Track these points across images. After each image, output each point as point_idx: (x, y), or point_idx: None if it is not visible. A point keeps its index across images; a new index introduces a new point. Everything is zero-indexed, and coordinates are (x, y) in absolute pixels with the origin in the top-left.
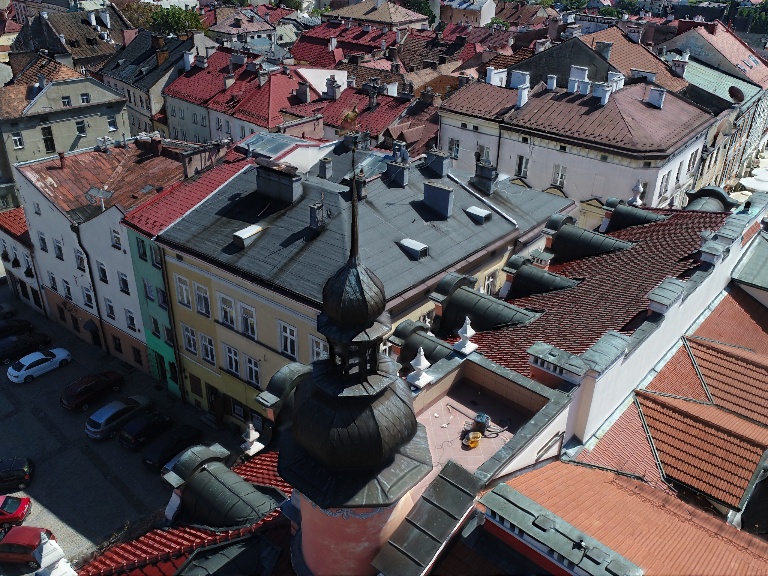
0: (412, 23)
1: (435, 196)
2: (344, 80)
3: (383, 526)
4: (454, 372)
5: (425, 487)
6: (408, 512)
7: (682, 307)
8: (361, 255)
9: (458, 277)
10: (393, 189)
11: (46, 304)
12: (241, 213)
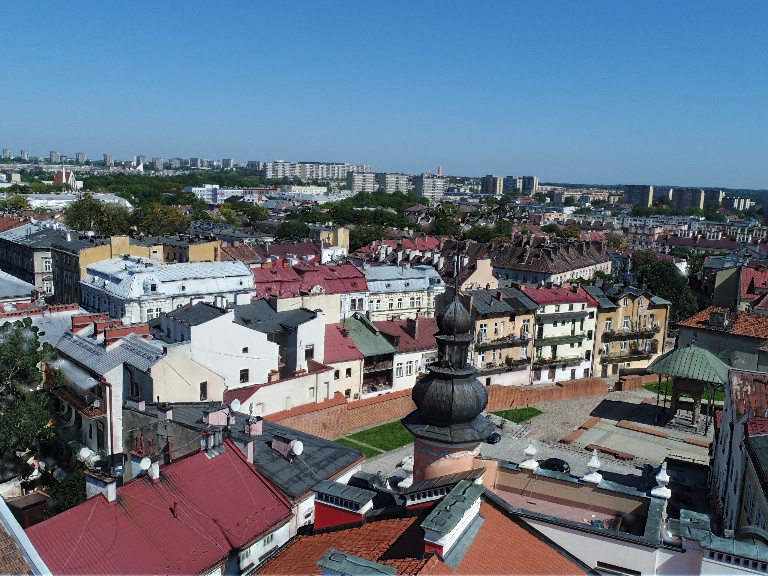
0: None
1: None
2: None
3: (428, 466)
4: (634, 500)
5: None
6: (447, 474)
7: None
8: None
9: None
10: None
11: (711, 492)
12: None
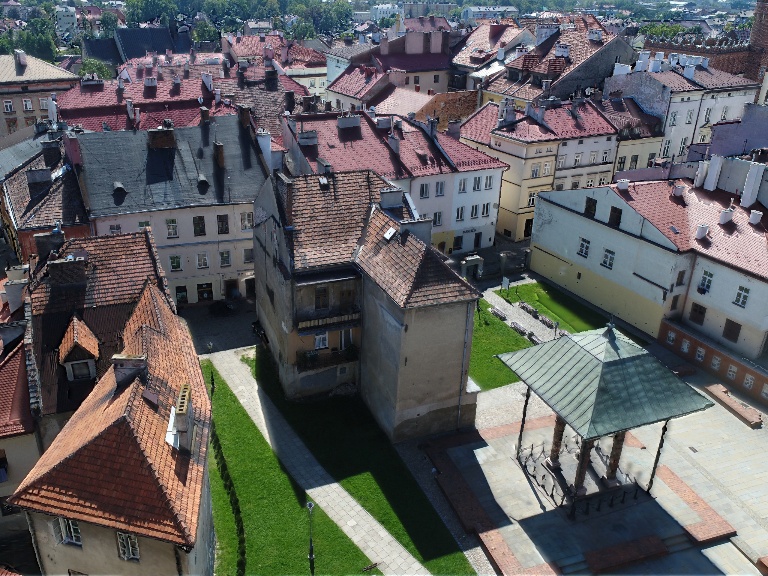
0: None
1: None
2: None
3: None
4: None
5: None
6: None
7: None
8: None
9: None
10: None
11: None
12: None
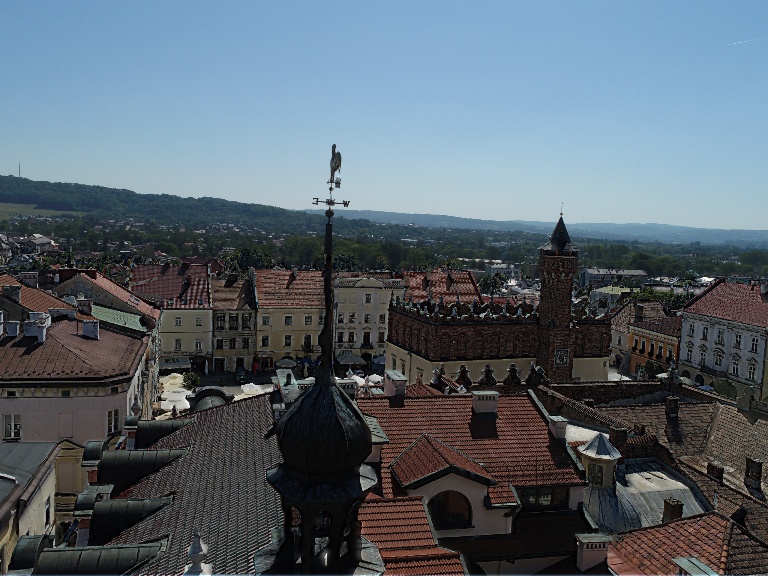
0: None
1: None
2: None
3: None
4: None
5: None
6: None
7: None
8: None
9: (38, 537)
10: None
11: None
12: None
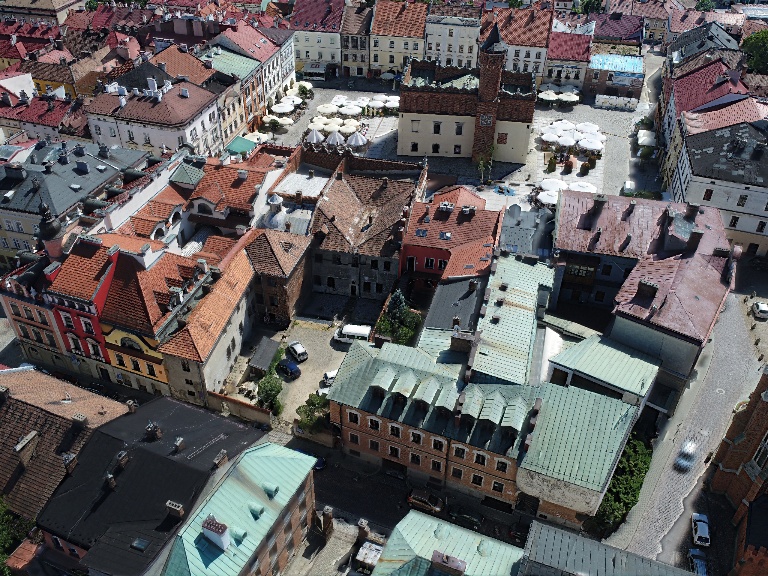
0: (71, 6)
1: (81, 165)
2: (30, 79)
3: (61, 244)
4: (78, 220)
5: (68, 237)
6: (66, 242)
7: (142, 193)
8: (56, 194)
9: (86, 196)
10: (64, 165)
11: None
12: (4, 187)
